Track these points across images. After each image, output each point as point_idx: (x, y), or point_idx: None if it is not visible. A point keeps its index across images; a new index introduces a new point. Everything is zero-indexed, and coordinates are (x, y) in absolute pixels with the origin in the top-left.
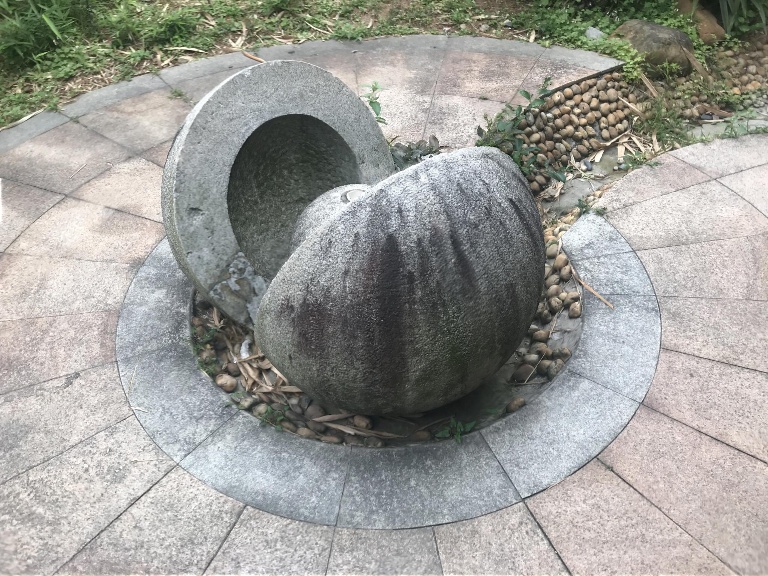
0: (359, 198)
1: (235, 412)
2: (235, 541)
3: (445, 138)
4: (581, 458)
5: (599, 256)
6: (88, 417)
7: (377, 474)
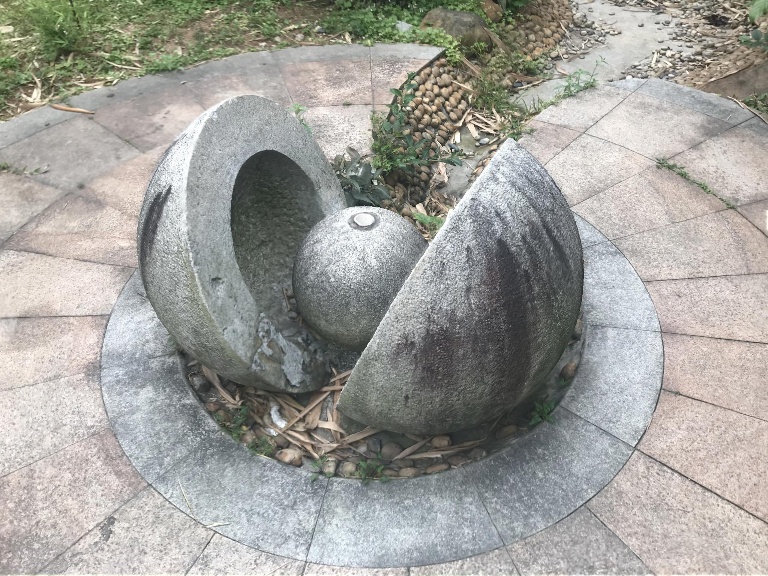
0: (456, 213)
1: (326, 482)
2: None
3: (338, 149)
4: (652, 394)
5: None
6: (162, 560)
7: (505, 481)
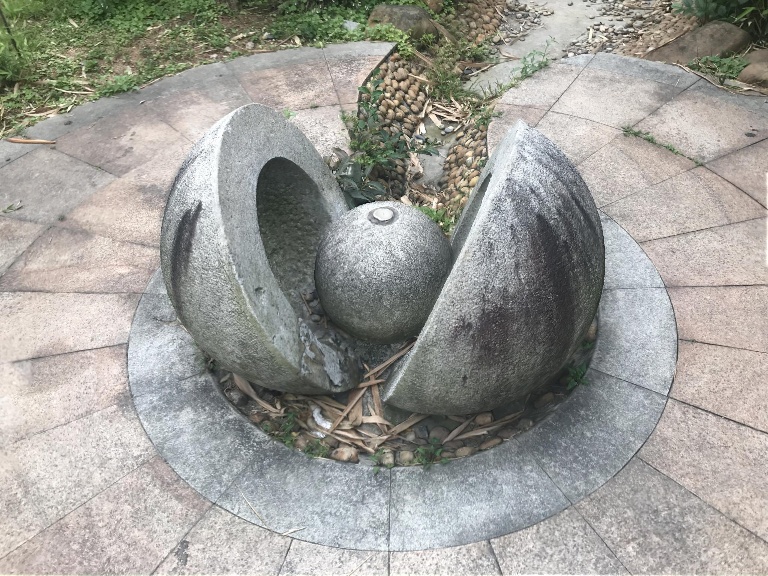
0: (495, 194)
1: (389, 473)
2: (513, 574)
3: None
4: (671, 345)
5: None
6: (246, 574)
7: (557, 445)
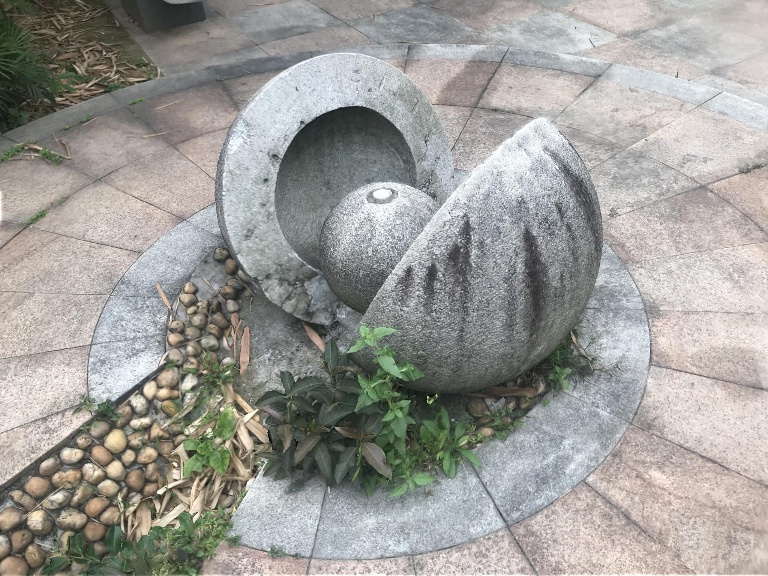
0: None
1: None
2: None
3: None
4: None
5: (133, 339)
6: None
7: None
